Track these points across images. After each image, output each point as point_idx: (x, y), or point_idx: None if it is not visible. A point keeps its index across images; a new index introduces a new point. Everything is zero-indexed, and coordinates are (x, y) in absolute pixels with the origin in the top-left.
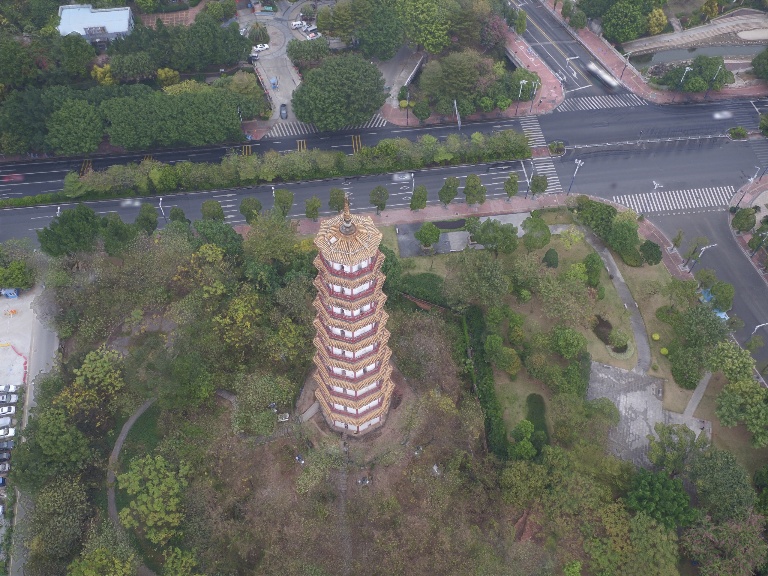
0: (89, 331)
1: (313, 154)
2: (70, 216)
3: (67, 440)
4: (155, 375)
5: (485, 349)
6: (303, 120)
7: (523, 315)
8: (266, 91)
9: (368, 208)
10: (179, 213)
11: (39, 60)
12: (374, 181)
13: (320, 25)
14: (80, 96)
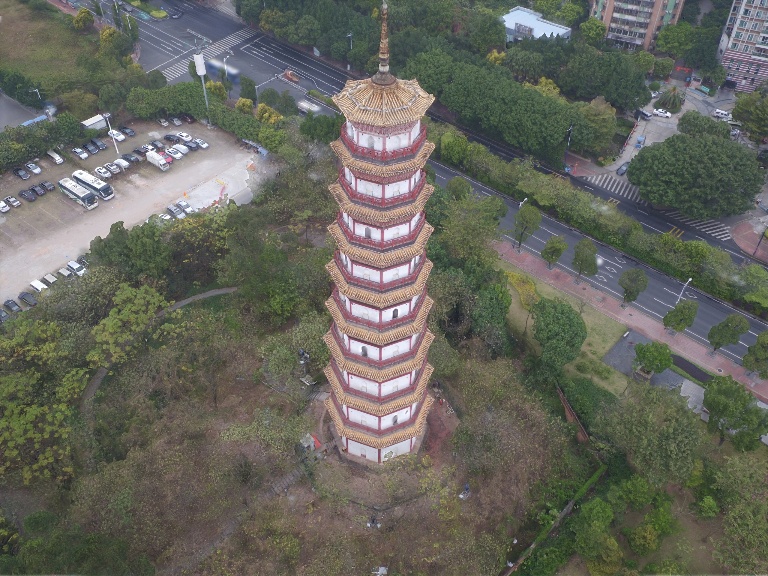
0: (271, 207)
1: (606, 207)
2: (343, 116)
3: (147, 245)
4: (252, 252)
5: (582, 511)
6: (631, 178)
7: (680, 526)
8: (625, 144)
9: (618, 294)
10: (429, 172)
11: (456, 24)
12: (653, 277)
13: (736, 109)
14: (452, 54)
